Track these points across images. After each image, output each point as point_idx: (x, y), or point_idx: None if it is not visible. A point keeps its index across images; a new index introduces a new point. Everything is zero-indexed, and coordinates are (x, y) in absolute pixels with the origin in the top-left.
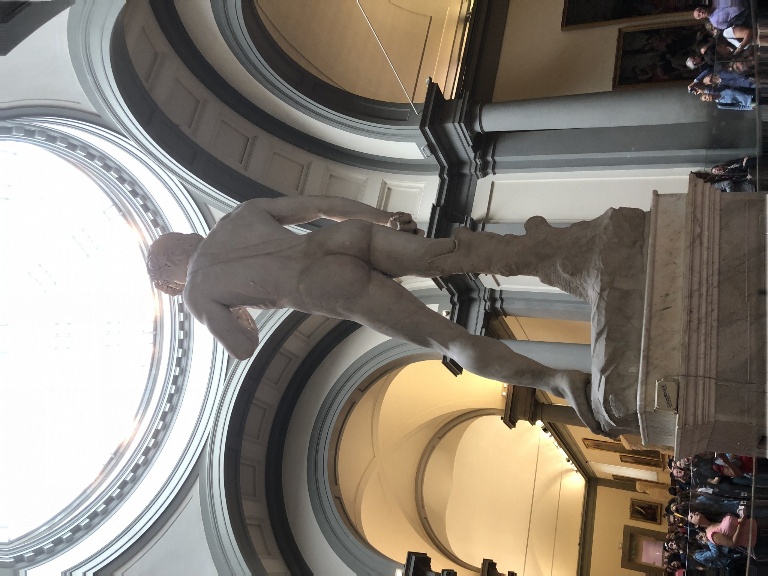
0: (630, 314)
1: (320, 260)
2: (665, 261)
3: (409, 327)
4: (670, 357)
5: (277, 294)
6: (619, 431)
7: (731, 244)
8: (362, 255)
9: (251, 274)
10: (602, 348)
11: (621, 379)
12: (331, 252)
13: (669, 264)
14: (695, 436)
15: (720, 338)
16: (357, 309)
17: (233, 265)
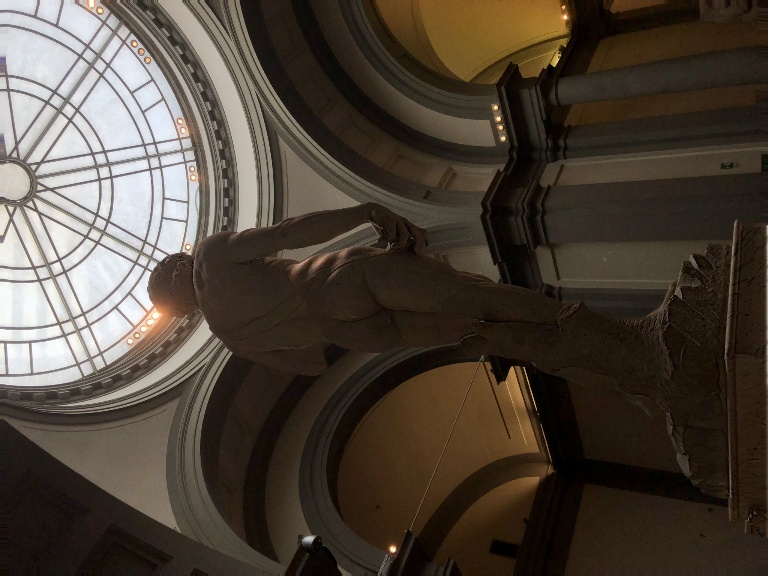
0: (713, 448)
1: (337, 334)
2: (750, 421)
3: None
4: (762, 494)
5: None
6: None
7: None
8: (375, 312)
9: (278, 344)
10: (686, 463)
11: None
12: None
13: (756, 425)
14: None
15: None
16: None
17: (254, 338)
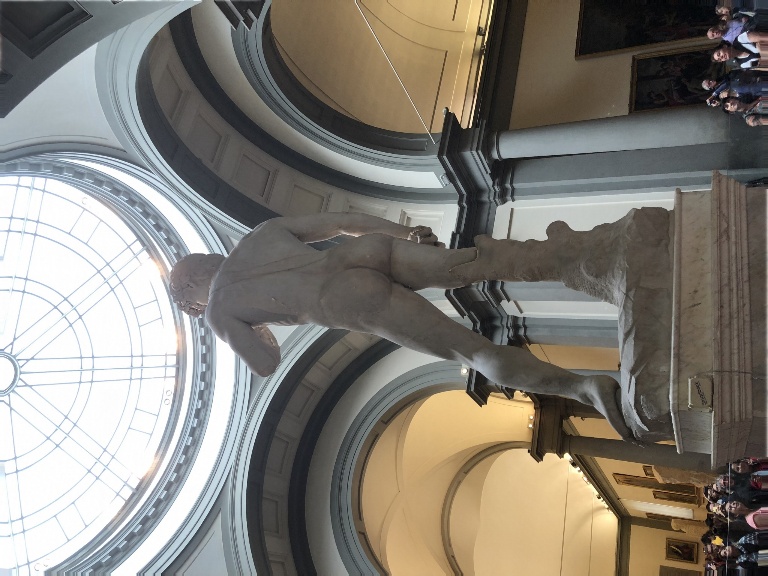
0: (658, 313)
1: (341, 274)
2: (692, 258)
3: (432, 339)
4: (702, 354)
5: (298, 310)
6: (652, 438)
7: (760, 238)
8: (383, 268)
9: (272, 290)
10: (631, 348)
11: (652, 379)
12: (352, 266)
13: (696, 261)
14: (733, 437)
15: (754, 333)
16: (379, 322)
17: (254, 282)
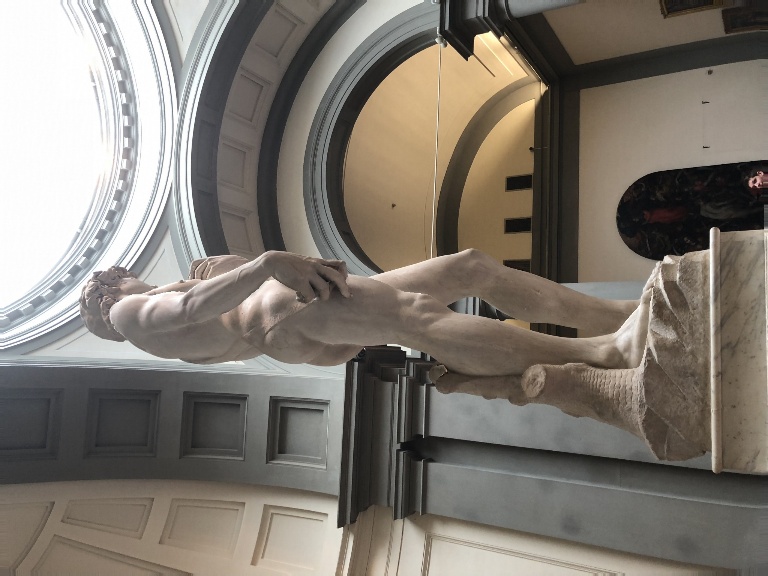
0: None
1: None
2: None
3: None
4: None
5: None
6: None
7: None
8: None
9: None
10: None
11: None
12: None
13: None
14: None
15: None
16: None
17: None
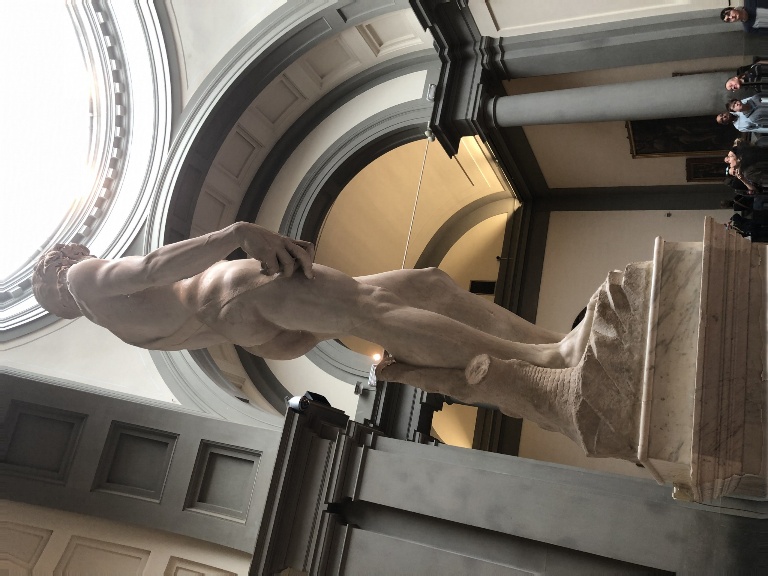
0: None
1: None
2: None
3: None
4: None
5: None
6: None
7: None
8: (281, 331)
9: None
10: None
11: None
12: None
13: None
14: None
15: None
16: None
17: (169, 346)
